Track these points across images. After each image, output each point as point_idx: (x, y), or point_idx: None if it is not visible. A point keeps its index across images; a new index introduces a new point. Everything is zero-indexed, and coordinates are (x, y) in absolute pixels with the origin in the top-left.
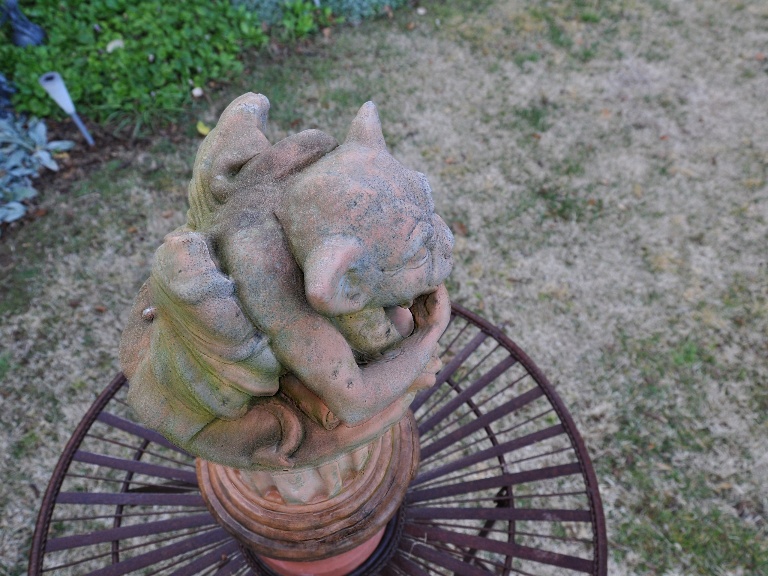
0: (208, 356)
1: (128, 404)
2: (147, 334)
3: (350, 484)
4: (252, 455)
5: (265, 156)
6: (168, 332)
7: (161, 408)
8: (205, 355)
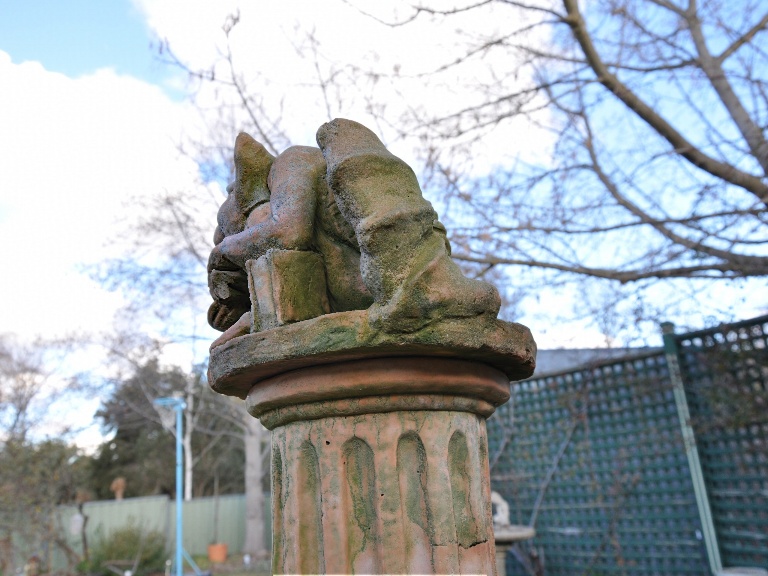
0: None
1: None
2: None
3: None
4: None
5: None
6: None
7: None
8: None
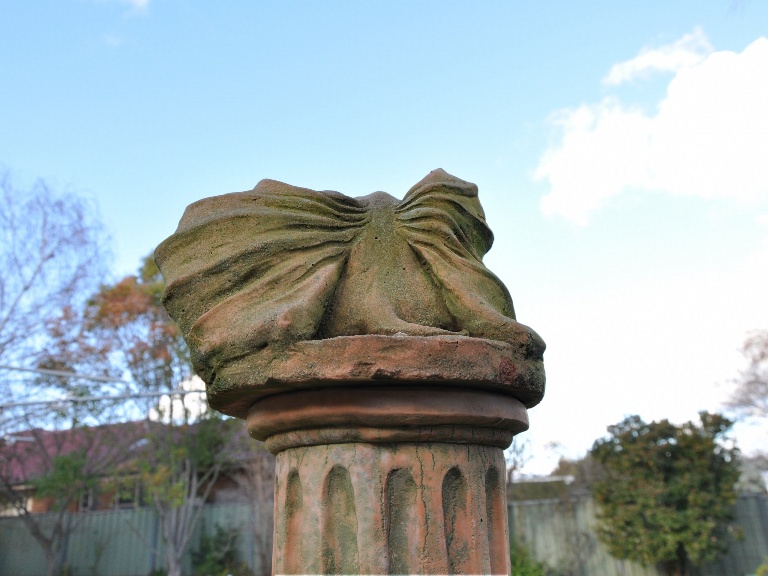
0: None
1: None
2: None
3: None
4: None
5: None
6: None
7: None
8: None
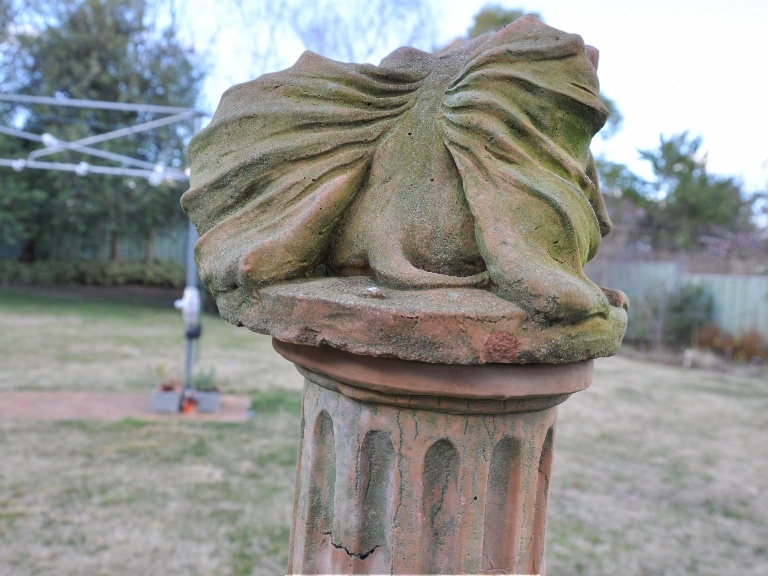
0: (603, 110)
1: (555, 287)
2: (417, 291)
3: (506, 575)
4: (614, 303)
5: (410, 51)
6: (528, 155)
7: (568, 274)
8: (568, 155)
